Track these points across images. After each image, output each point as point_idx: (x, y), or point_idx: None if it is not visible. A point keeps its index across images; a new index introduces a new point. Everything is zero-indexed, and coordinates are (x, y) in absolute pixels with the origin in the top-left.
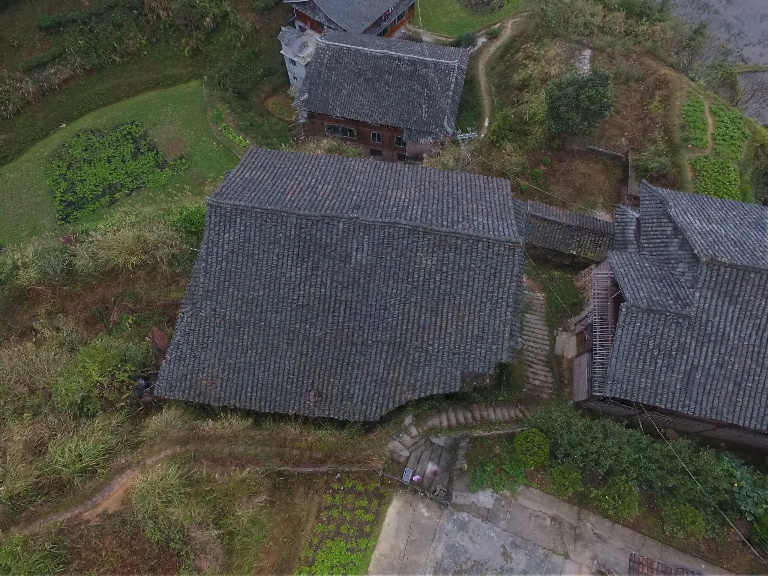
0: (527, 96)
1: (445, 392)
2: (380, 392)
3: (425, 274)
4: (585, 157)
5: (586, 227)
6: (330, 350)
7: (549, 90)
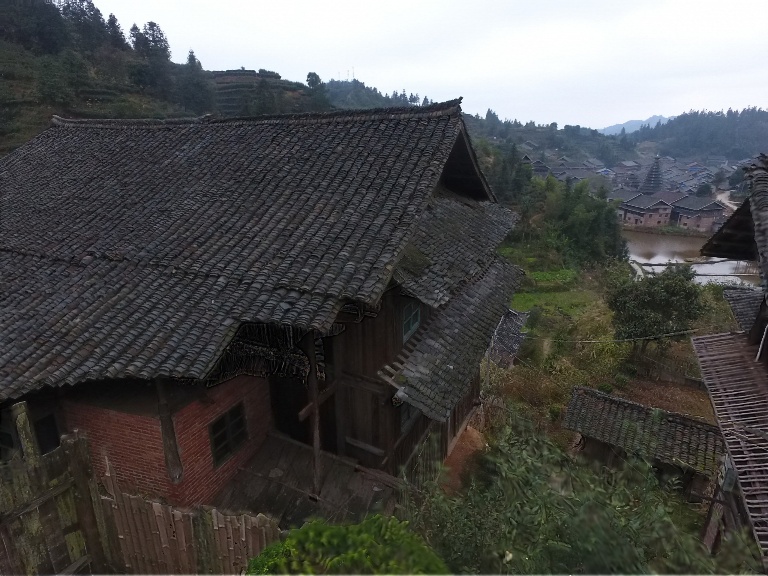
0: (594, 339)
1: (158, 374)
2: (4, 354)
3: (267, 165)
4: (688, 391)
5: (697, 422)
6: (7, 271)
7: (610, 291)
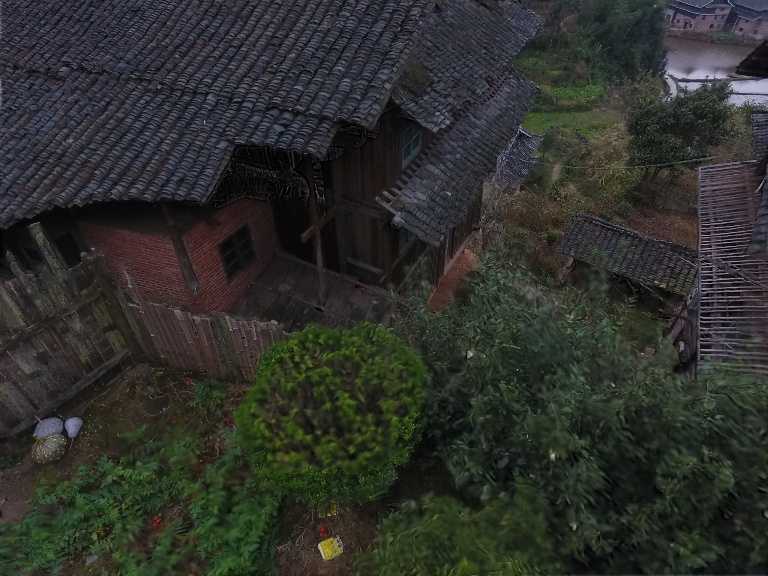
0: (606, 165)
1: (160, 197)
2: (7, 175)
3: None
4: (688, 219)
5: None
6: None
7: (633, 112)
